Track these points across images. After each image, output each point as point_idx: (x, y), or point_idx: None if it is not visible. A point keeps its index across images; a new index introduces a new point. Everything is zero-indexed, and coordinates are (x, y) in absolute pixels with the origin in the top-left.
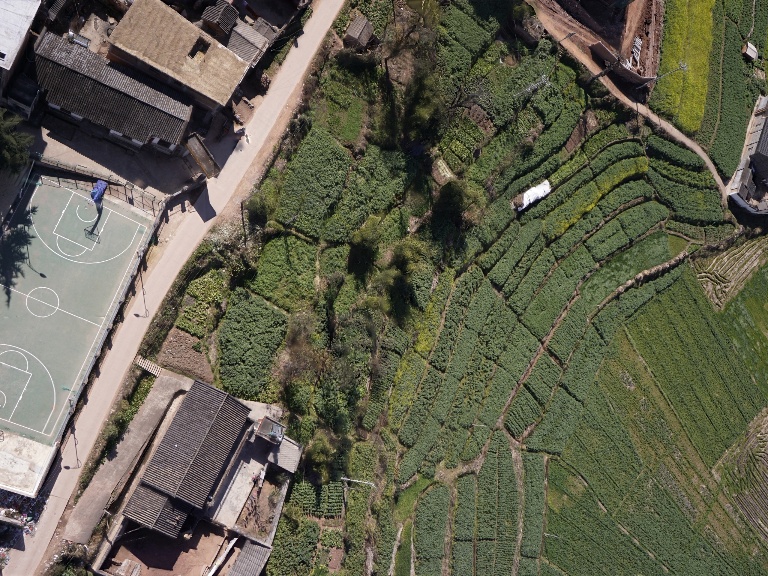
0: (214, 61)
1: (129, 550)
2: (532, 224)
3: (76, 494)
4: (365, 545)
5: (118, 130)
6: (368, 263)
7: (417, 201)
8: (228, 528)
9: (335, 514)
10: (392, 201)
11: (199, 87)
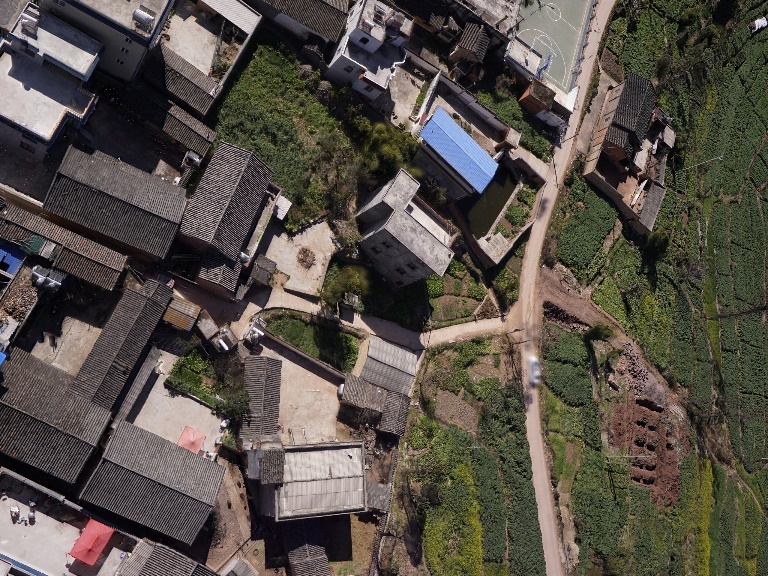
0: None
1: (598, 171)
2: (759, 44)
3: (579, 125)
4: (696, 219)
5: None
6: (683, 41)
7: (705, 7)
8: (641, 173)
9: (683, 190)
10: (694, 3)
11: None
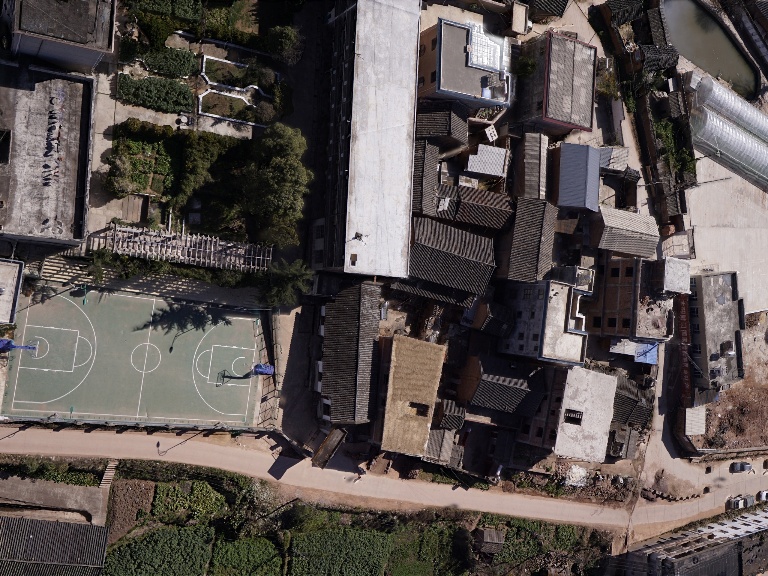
0: (415, 425)
1: None
2: None
3: None
4: None
5: (324, 368)
6: None
7: None
8: None
9: None
10: None
11: (388, 421)
